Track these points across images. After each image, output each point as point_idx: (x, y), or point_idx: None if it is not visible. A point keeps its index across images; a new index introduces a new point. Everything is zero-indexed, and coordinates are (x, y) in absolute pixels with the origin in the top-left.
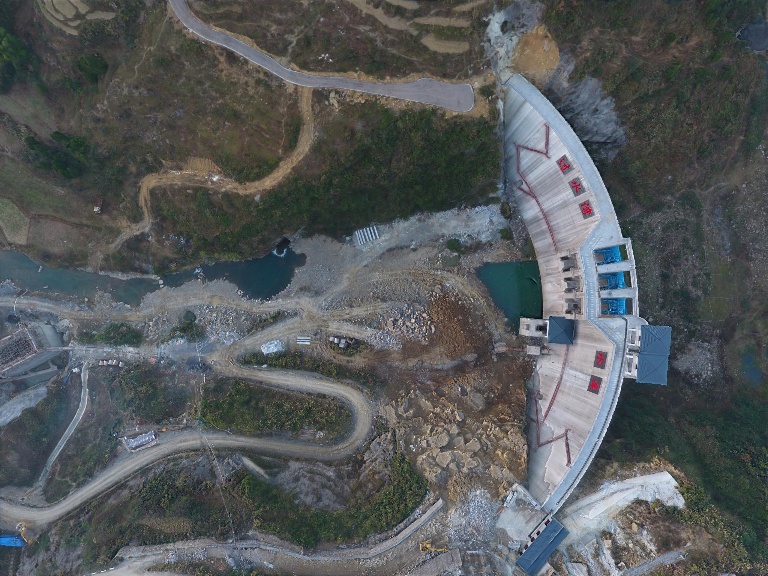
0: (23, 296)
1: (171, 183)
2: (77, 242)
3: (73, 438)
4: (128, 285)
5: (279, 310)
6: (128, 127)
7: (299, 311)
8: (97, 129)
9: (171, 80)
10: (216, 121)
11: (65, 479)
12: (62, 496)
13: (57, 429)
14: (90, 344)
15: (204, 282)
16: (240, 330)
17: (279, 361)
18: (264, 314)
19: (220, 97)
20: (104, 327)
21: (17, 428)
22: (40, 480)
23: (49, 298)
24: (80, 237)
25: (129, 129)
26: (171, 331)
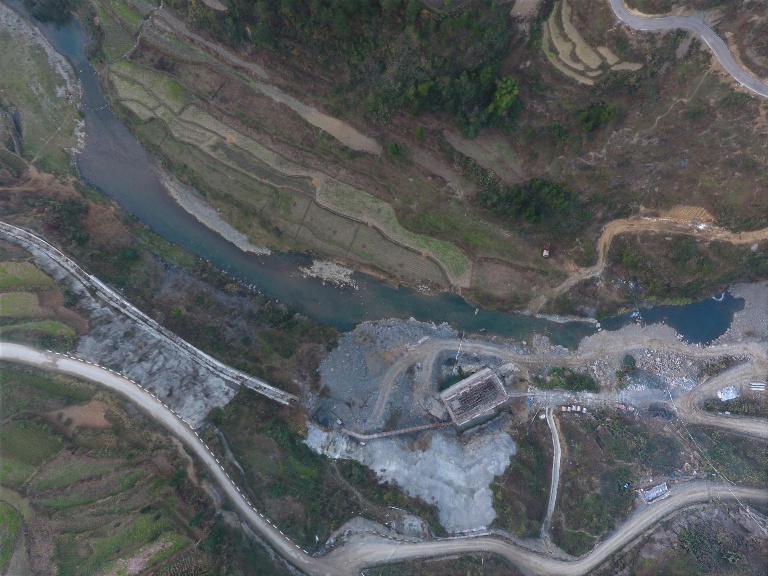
0: (468, 339)
1: (646, 230)
2: (521, 285)
3: (561, 487)
4: (564, 328)
5: (725, 355)
6: (622, 175)
7: (748, 356)
8: (582, 176)
9: (693, 131)
10: (724, 171)
11: (579, 531)
12: (589, 549)
13: (544, 478)
14: (549, 389)
15: (643, 326)
16: (693, 376)
17: (743, 408)
18: (708, 359)
19: (740, 148)
20: (546, 371)
21: (517, 478)
22: (542, 531)
23: (492, 341)
24: (524, 280)
25: (622, 177)
26: (617, 376)
